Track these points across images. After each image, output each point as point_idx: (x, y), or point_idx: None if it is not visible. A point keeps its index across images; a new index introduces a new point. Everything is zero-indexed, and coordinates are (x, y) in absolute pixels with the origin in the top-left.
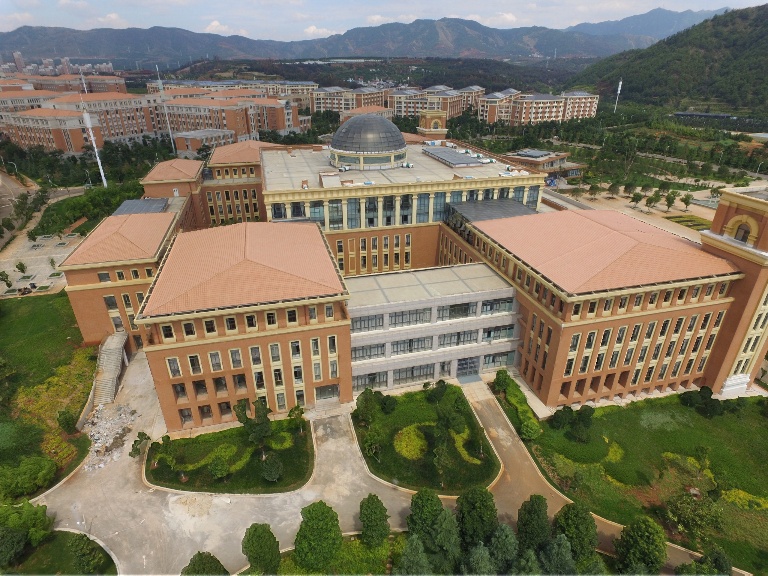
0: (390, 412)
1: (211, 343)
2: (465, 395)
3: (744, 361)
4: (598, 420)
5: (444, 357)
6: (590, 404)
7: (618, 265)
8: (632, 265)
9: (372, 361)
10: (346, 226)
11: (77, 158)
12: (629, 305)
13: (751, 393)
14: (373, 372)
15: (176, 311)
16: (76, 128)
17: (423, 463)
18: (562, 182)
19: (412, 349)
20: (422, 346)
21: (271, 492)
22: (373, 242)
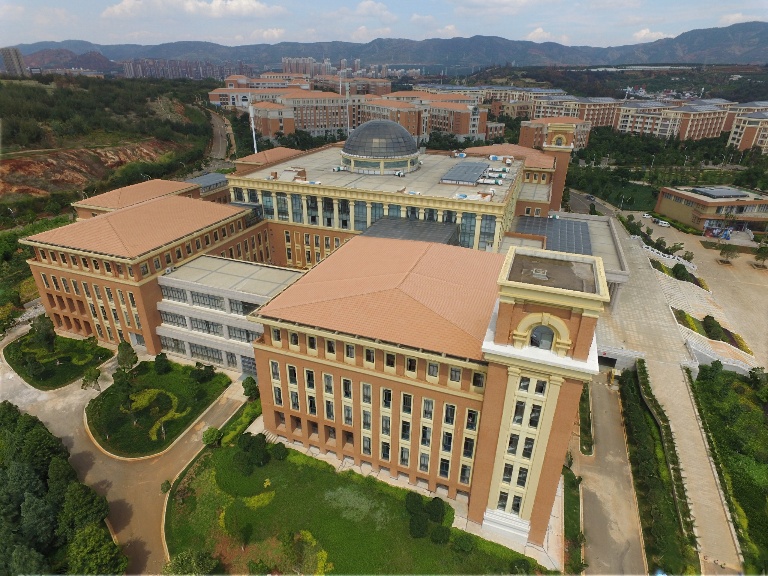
0: (162, 374)
1: (59, 270)
2: (227, 389)
3: (511, 496)
4: (292, 466)
5: (228, 348)
6: (314, 451)
7: (339, 303)
8: (355, 308)
9: (178, 329)
10: (291, 219)
11: (270, 141)
12: (337, 352)
13: (533, 551)
14: (173, 337)
15: (41, 240)
16: (275, 118)
17: (122, 417)
18: (746, 236)
19: (210, 331)
20: (217, 331)
21: (31, 384)
22: (316, 240)
